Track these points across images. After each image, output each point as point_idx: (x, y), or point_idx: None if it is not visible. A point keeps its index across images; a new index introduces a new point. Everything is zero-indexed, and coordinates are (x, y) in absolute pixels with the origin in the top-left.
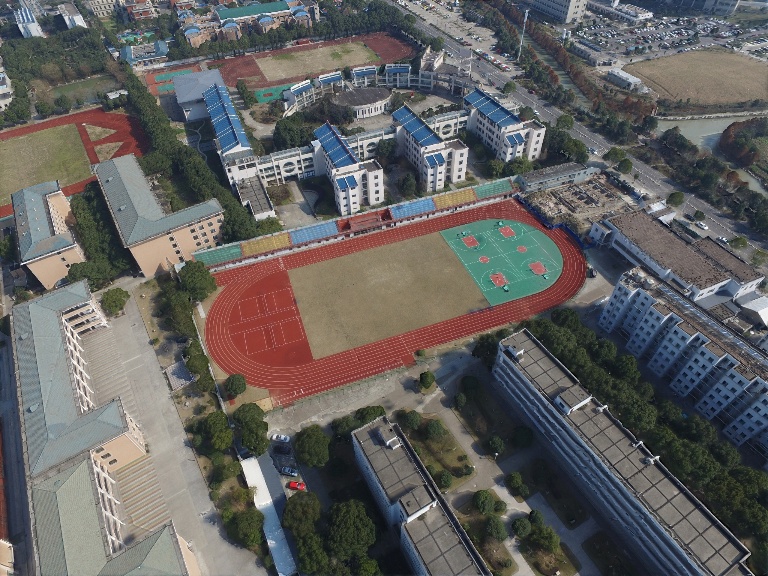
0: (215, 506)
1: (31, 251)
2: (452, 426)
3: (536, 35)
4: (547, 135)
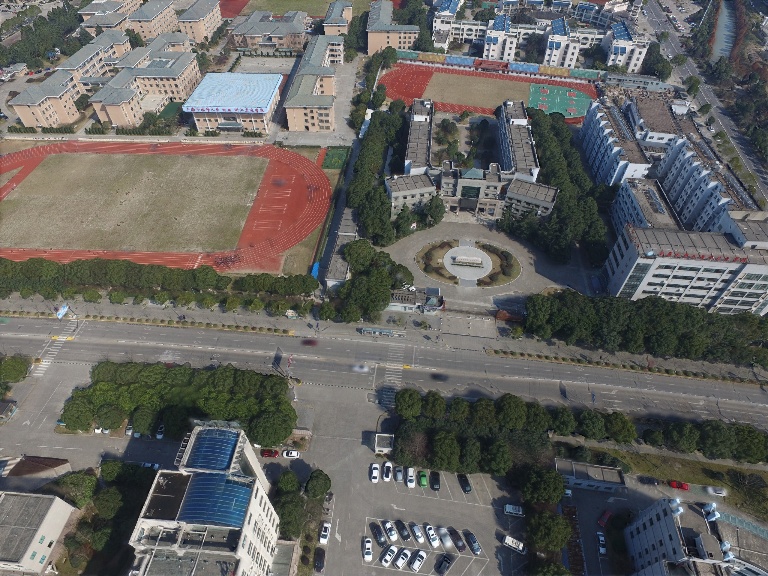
0: (350, 118)
1: (329, 20)
2: (463, 134)
3: (739, 18)
4: (651, 58)
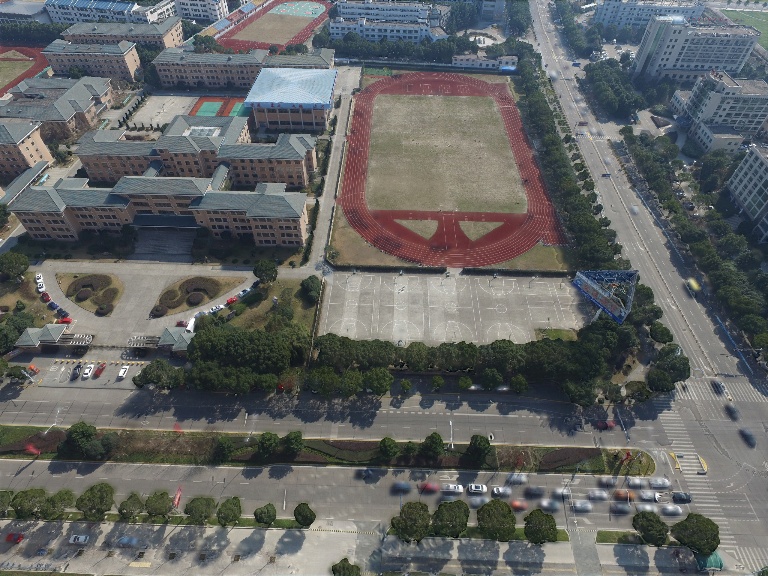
0: None
1: (121, 48)
2: None
3: None
4: None
